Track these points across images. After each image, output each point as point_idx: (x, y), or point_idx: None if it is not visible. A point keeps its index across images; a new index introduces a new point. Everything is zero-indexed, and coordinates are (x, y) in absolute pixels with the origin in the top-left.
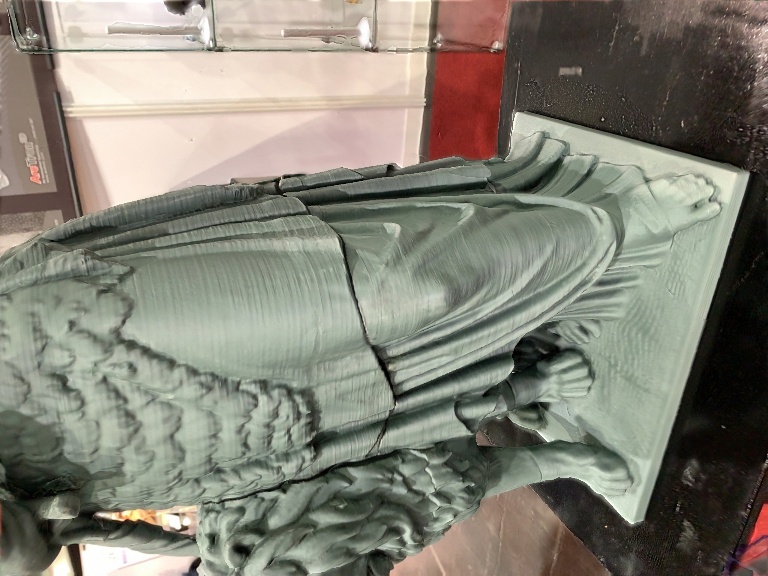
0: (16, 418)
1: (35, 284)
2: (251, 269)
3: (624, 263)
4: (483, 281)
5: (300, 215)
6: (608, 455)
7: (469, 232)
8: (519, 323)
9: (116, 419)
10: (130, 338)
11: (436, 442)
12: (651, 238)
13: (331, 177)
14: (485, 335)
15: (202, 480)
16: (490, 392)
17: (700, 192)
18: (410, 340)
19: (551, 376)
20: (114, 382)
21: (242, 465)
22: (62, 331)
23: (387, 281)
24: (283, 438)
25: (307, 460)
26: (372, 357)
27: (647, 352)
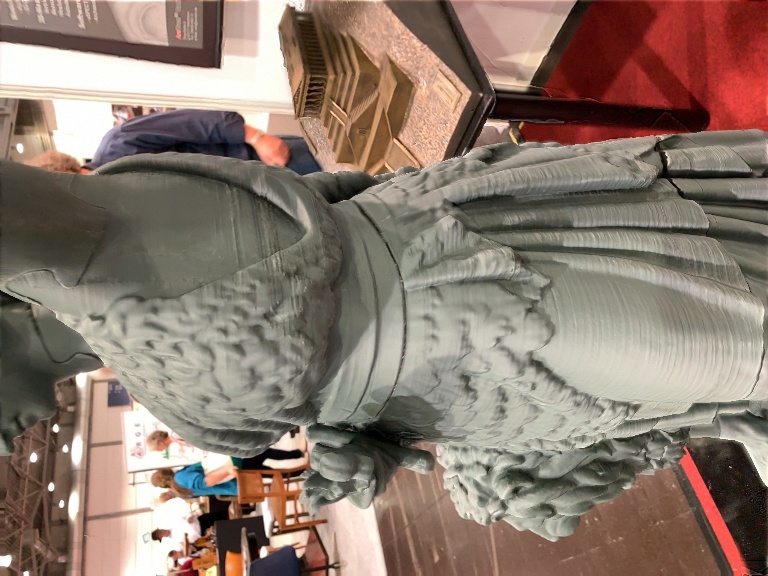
0: (418, 402)
1: (463, 283)
2: (673, 321)
3: None
4: None
5: (706, 238)
6: None
7: None
8: None
9: (493, 414)
10: (539, 360)
11: None
12: None
13: (722, 165)
14: None
15: None
16: None
17: None
18: None
19: None
20: (506, 388)
21: None
22: (488, 346)
23: None
24: (597, 433)
25: None
26: None
27: None
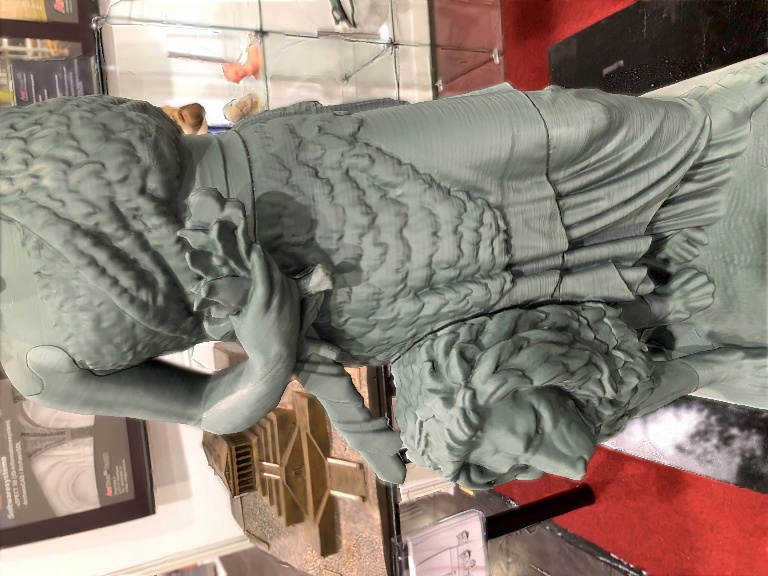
0: (281, 197)
1: None
2: None
3: (715, 152)
4: (623, 117)
5: None
6: (754, 348)
7: (599, 91)
8: (652, 178)
9: (359, 206)
10: (364, 142)
11: (605, 300)
12: (733, 119)
13: None
14: (629, 184)
15: (420, 295)
16: (636, 265)
17: (762, 70)
18: (572, 178)
19: (674, 293)
20: (354, 176)
21: (453, 283)
22: (313, 132)
23: (557, 98)
24: (488, 249)
25: (507, 281)
26: (548, 183)
27: (759, 230)
